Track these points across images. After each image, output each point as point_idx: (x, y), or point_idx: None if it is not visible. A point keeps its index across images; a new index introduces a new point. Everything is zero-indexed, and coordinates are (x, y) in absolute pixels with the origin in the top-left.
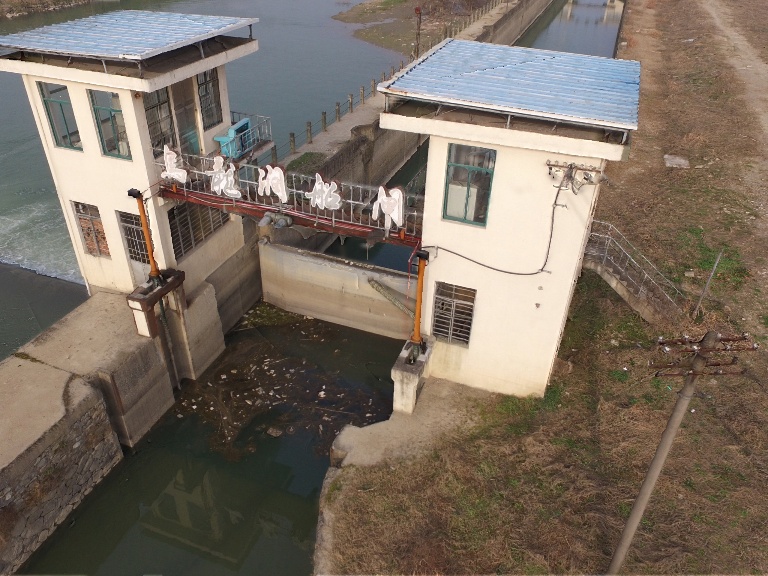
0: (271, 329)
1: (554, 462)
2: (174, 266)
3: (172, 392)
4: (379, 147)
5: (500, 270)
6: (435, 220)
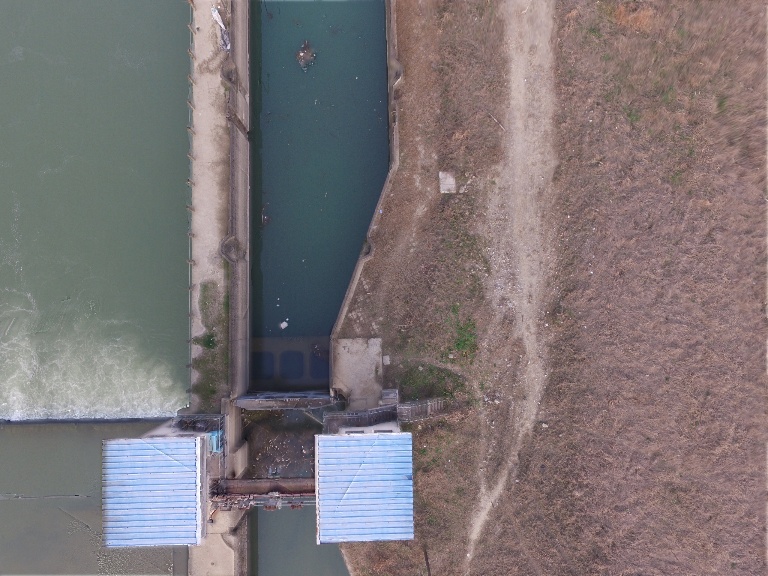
0: (260, 419)
1: None
2: None
3: None
4: (238, 227)
5: None
6: None
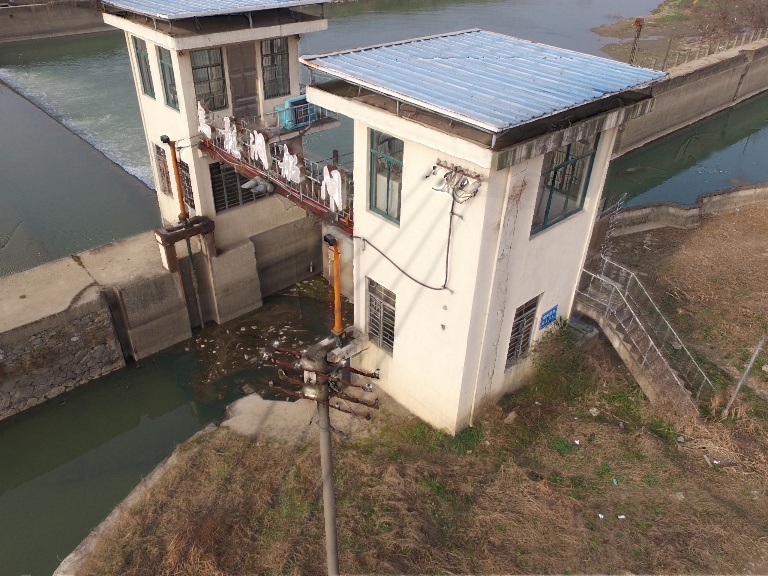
0: (311, 302)
1: (401, 500)
2: (212, 216)
3: (190, 327)
4: None
5: (411, 277)
6: (362, 209)
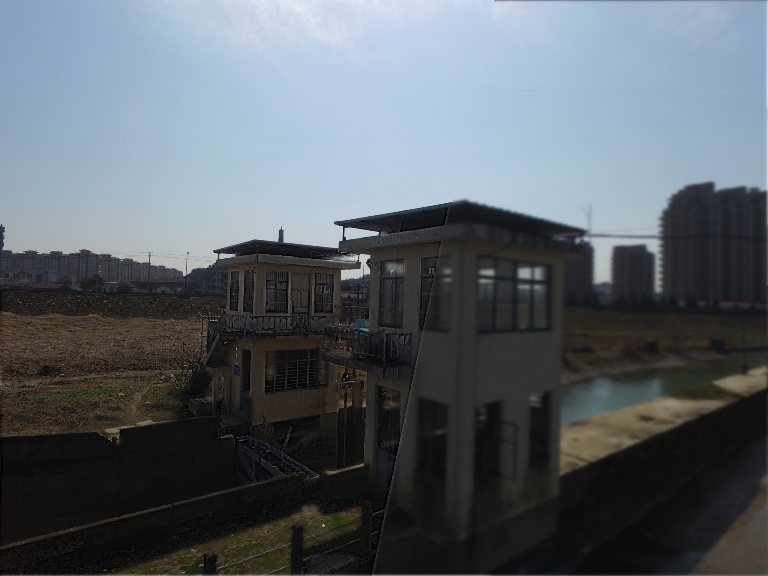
0: None
1: None
2: None
3: None
4: None
5: None
6: None
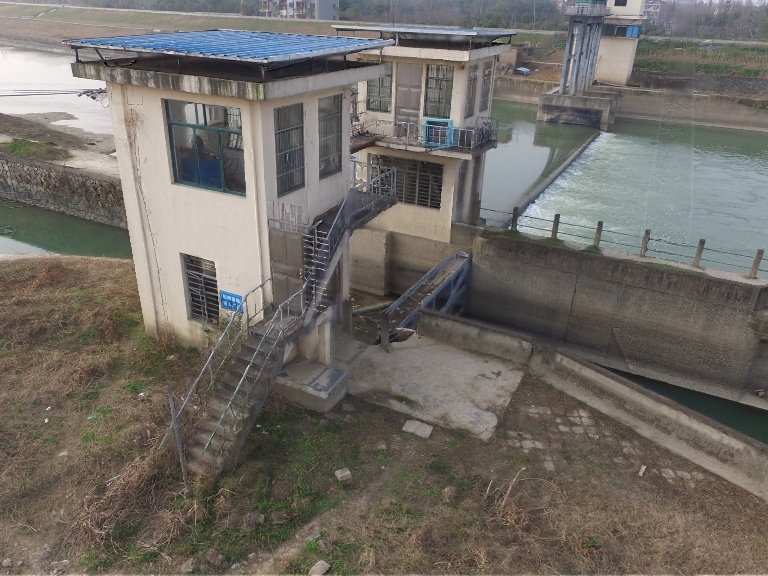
0: None
1: None
2: None
3: None
4: None
5: None
6: None
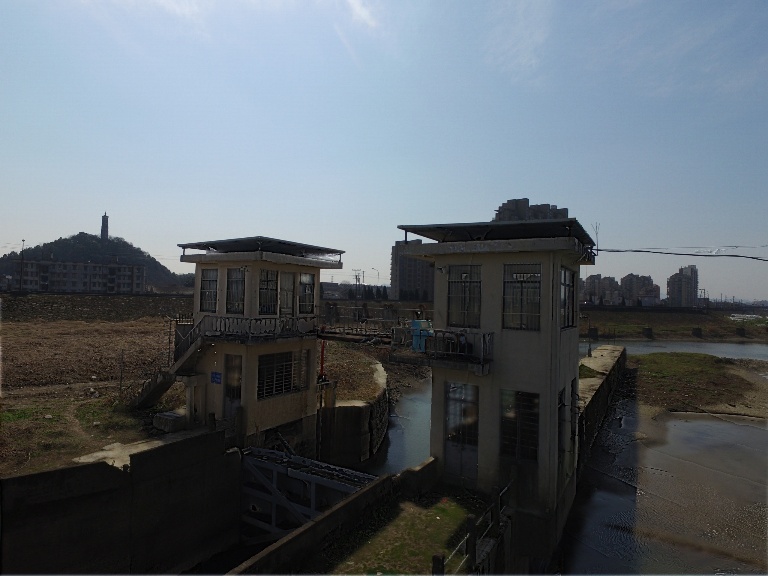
0: None
1: None
2: None
3: None
4: None
5: None
6: None
